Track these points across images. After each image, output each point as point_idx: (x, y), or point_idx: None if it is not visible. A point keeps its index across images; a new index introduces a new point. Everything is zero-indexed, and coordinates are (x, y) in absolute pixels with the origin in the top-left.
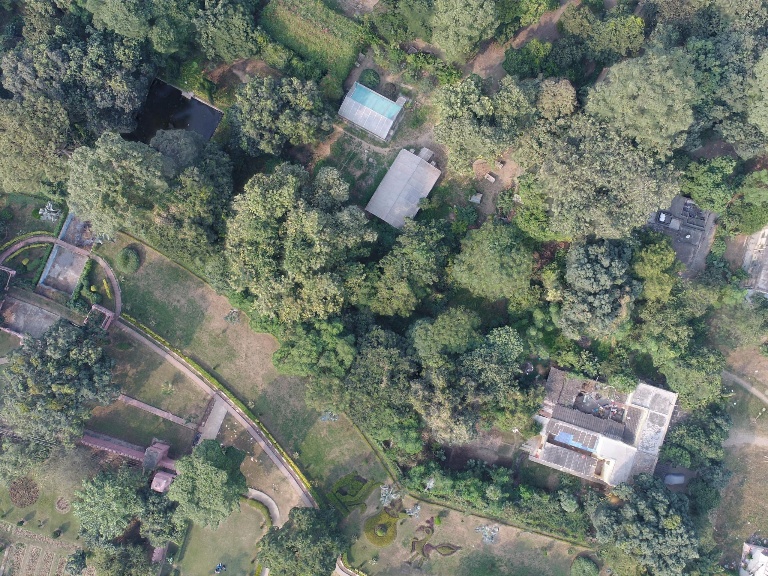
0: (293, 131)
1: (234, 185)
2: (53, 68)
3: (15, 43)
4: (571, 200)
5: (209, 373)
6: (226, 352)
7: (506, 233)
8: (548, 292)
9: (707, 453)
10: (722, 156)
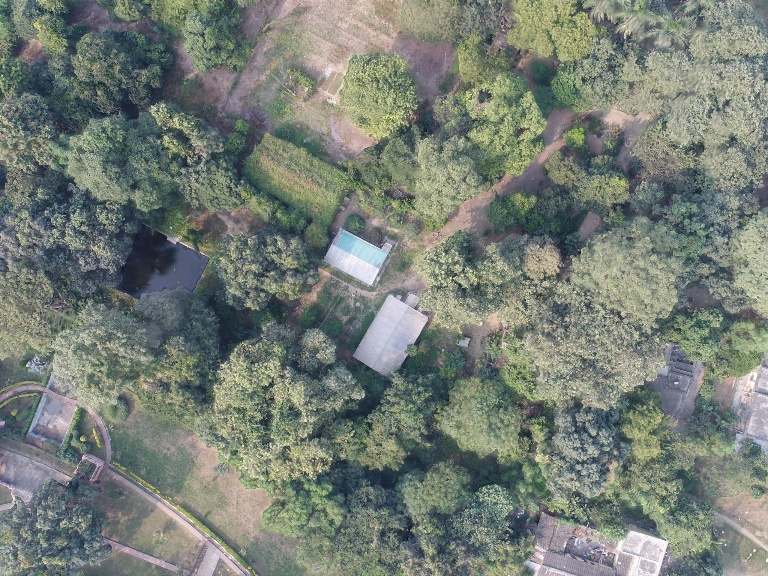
0: (278, 290)
1: (221, 341)
2: (36, 236)
3: None
4: (557, 370)
5: (200, 521)
6: (217, 499)
7: (494, 392)
8: (536, 456)
9: None
10: (709, 310)
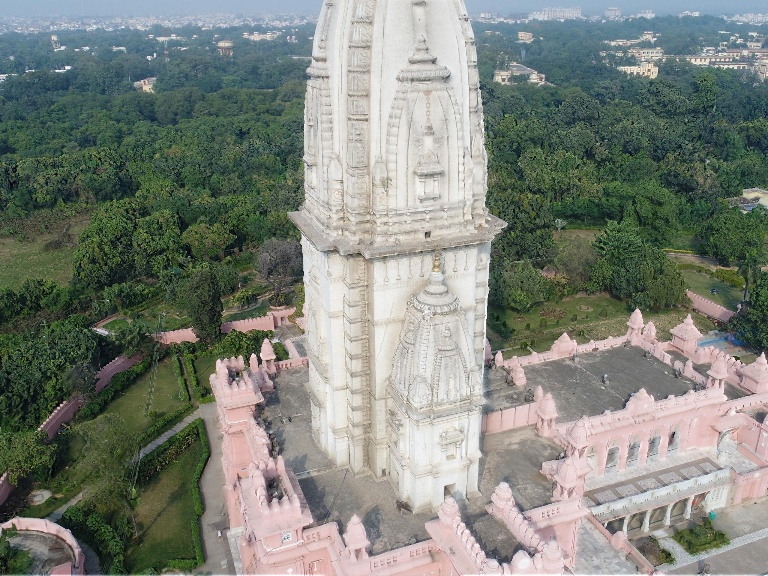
0: None
1: None
2: None
3: None
4: None
5: None
6: None
7: None
8: (667, 155)
9: None
10: None
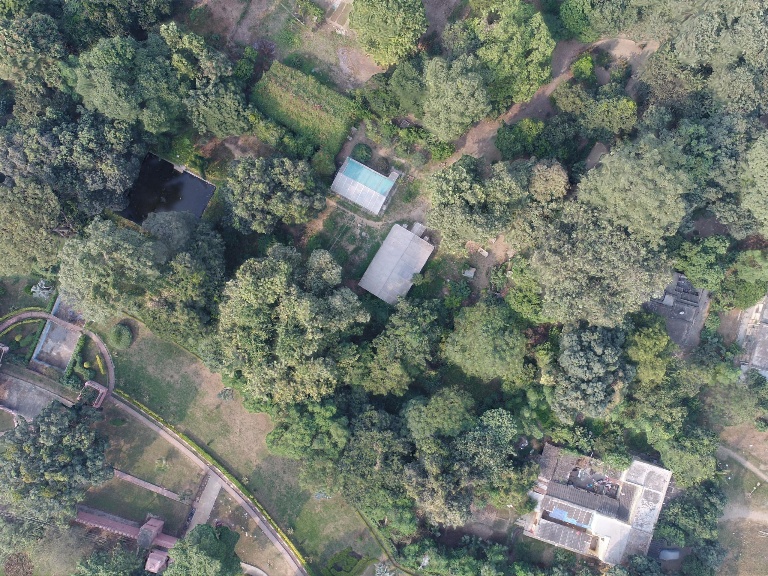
0: (285, 212)
1: (226, 264)
2: (43, 153)
3: (6, 121)
4: (564, 288)
5: (203, 449)
6: (220, 428)
7: (499, 315)
8: None
9: (701, 534)
10: (715, 236)
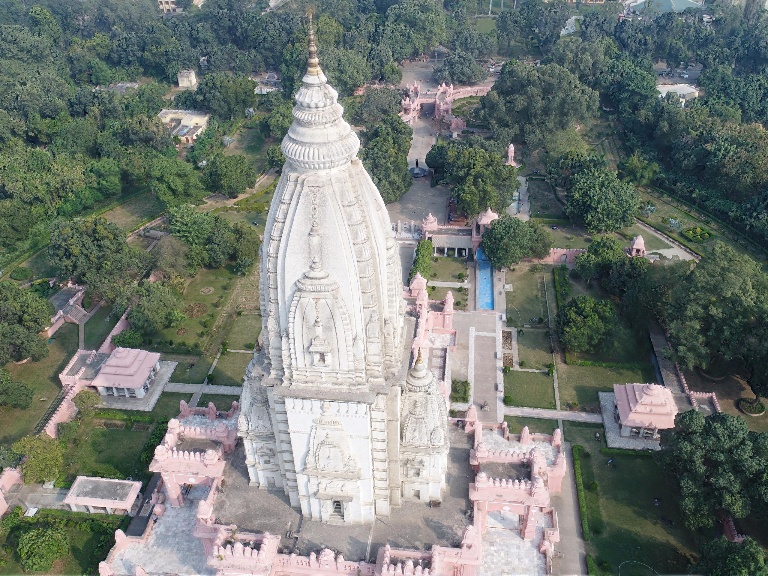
0: None
1: None
2: None
3: None
4: None
5: None
6: None
7: None
8: None
9: (188, 93)
10: None
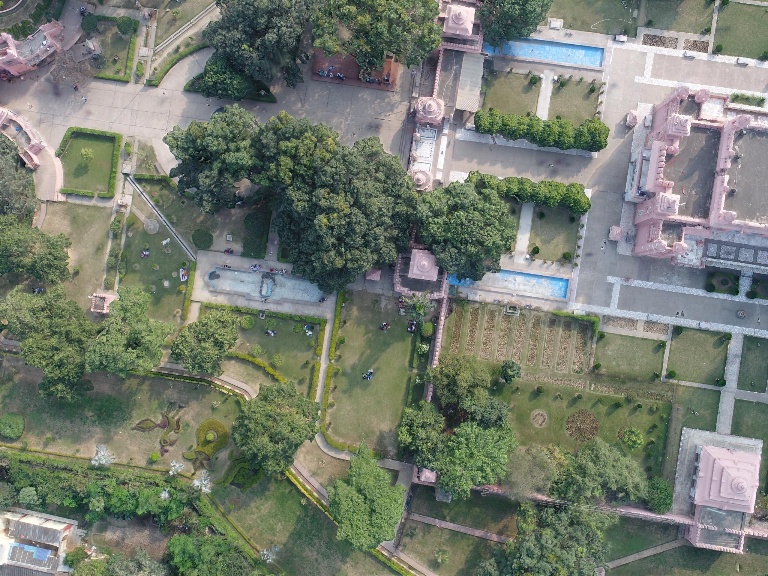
0: None
1: None
2: None
3: None
4: None
5: (403, 575)
6: None
7: None
8: None
9: None
10: None
